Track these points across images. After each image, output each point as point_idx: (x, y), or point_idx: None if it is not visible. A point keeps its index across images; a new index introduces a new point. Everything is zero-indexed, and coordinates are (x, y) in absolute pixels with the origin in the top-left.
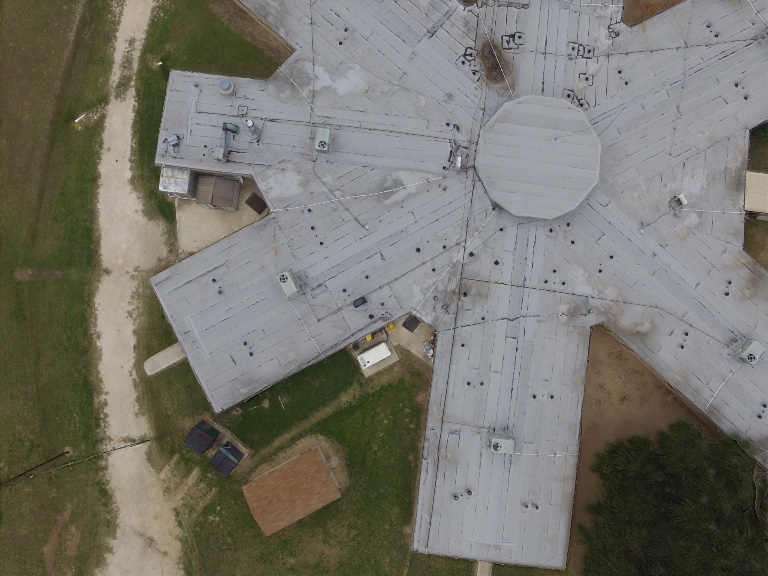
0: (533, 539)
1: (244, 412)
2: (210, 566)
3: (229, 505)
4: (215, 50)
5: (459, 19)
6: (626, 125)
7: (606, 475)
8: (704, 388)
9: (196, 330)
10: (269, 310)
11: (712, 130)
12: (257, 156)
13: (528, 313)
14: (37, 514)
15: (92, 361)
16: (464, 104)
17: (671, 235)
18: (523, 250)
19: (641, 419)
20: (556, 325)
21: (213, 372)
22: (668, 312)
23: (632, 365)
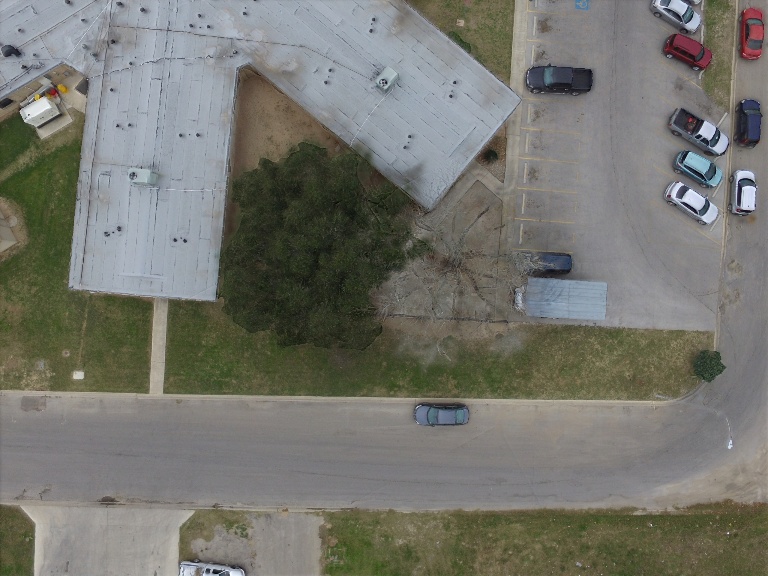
0: (183, 272)
1: None
2: None
3: None
4: None
5: None
6: None
7: (243, 201)
8: (349, 122)
9: None
10: None
11: None
12: None
13: (173, 56)
14: None
15: None
16: None
17: None
18: None
19: None
20: (202, 67)
21: None
22: (311, 49)
23: (299, 117)
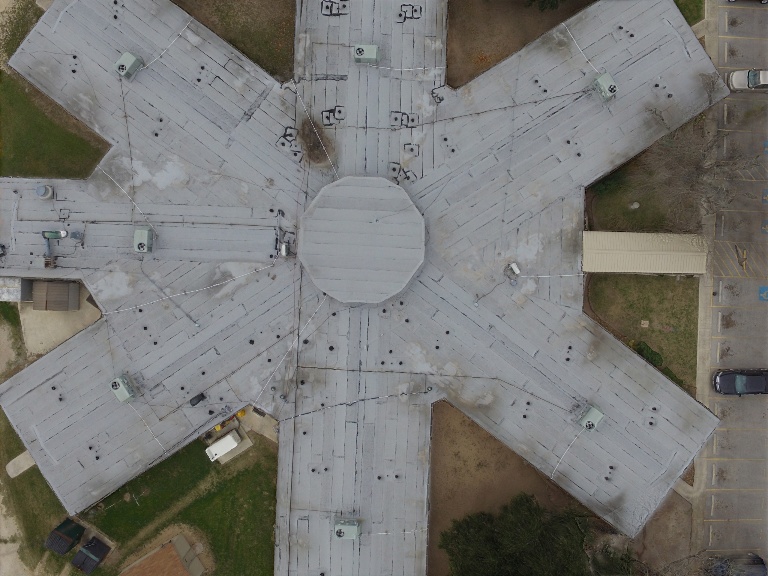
0: None
1: (107, 507)
2: None
3: None
4: (41, 146)
5: (277, 98)
6: (455, 195)
7: (451, 550)
8: (549, 454)
9: (41, 439)
10: (110, 414)
11: (545, 191)
12: (84, 259)
13: (367, 396)
14: None
15: None
16: (286, 189)
17: (508, 304)
18: (356, 334)
19: (496, 484)
20: (396, 405)
21: (63, 478)
22: (508, 383)
23: (485, 431)
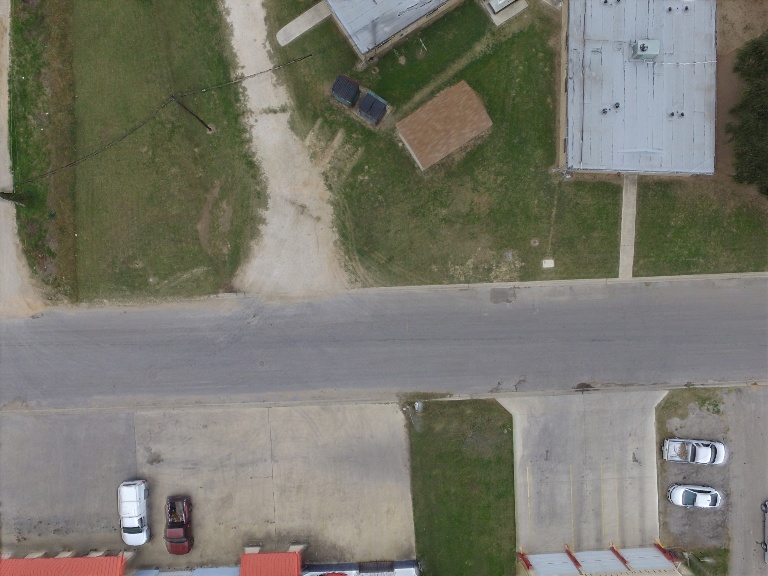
0: (681, 146)
1: (382, 70)
2: (364, 225)
3: (377, 163)
4: None
5: None
6: None
7: (748, 70)
8: None
9: None
10: None
11: None
12: None
13: None
14: (187, 193)
15: (224, 37)
16: None
17: None
18: None
19: None
20: None
21: (355, 14)
22: None
23: None
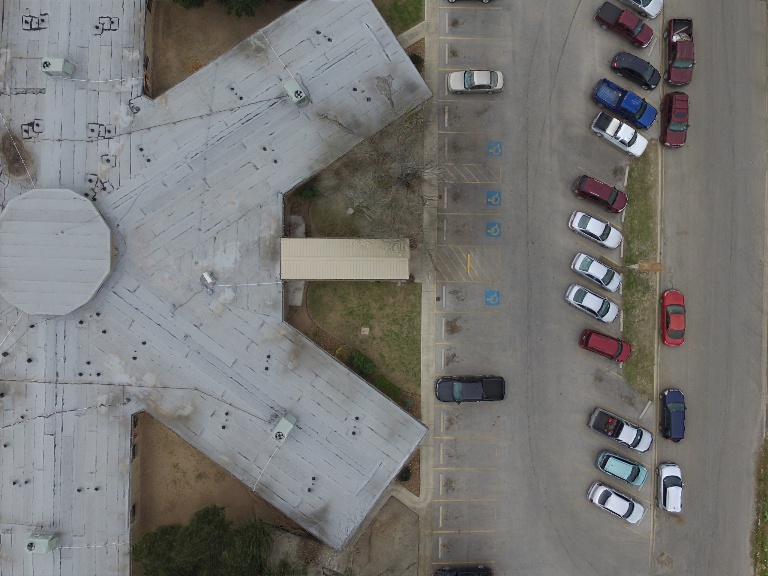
0: None
1: None
2: None
3: None
4: None
5: None
6: (150, 205)
7: None
8: (251, 466)
9: None
10: None
11: (243, 199)
12: None
13: (65, 408)
14: None
15: None
16: None
17: (206, 314)
18: (52, 346)
19: (214, 496)
20: (96, 417)
21: None
22: (206, 393)
23: None
